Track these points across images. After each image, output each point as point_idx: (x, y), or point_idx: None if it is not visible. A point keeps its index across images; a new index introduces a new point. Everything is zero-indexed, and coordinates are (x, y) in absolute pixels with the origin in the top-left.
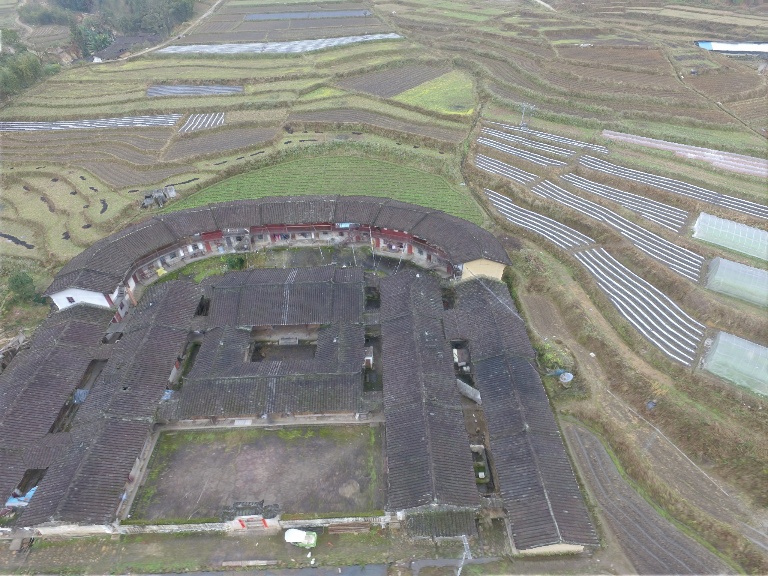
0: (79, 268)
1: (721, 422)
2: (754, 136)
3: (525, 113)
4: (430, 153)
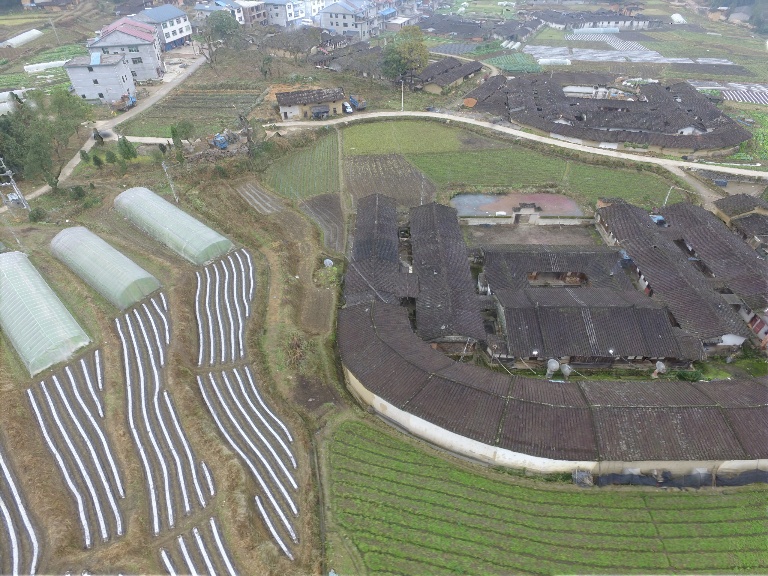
0: None
1: (253, 230)
2: None
3: None
4: None
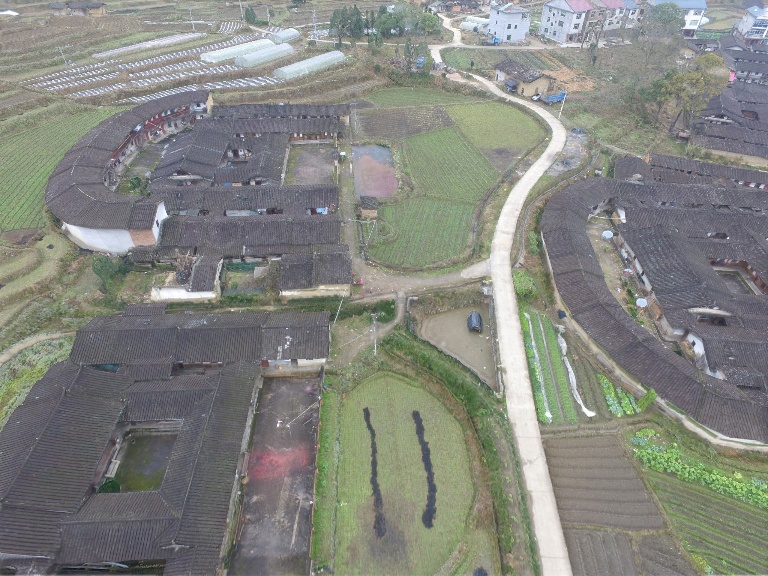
0: (132, 204)
1: None
2: (143, 33)
3: (29, 69)
4: (41, 109)
